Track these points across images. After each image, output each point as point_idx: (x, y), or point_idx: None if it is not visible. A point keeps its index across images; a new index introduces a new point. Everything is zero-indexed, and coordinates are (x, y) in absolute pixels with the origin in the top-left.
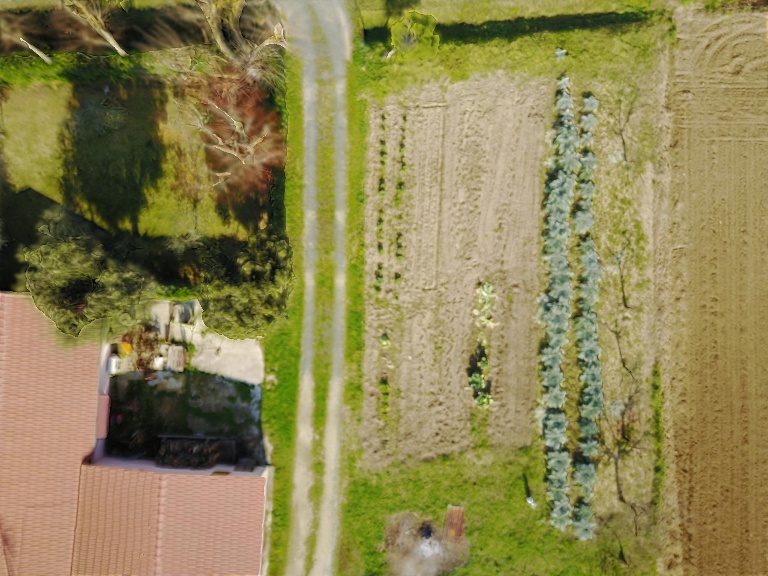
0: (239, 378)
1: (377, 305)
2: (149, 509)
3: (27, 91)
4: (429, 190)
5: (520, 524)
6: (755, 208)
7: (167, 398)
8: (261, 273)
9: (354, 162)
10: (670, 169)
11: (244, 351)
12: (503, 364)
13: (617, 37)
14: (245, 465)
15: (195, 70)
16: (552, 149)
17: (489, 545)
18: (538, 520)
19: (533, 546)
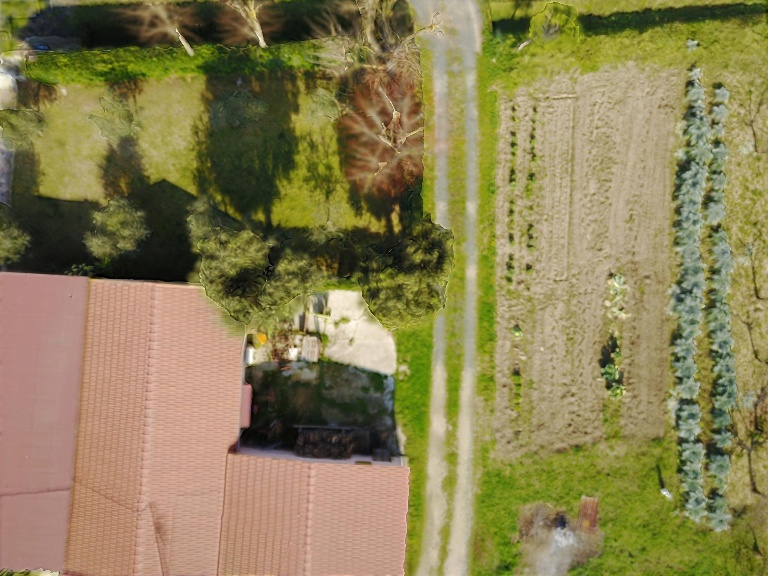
0: (372, 369)
1: (508, 296)
2: (298, 498)
3: (160, 83)
4: (559, 181)
5: (654, 515)
6: None
7: (301, 388)
8: (427, 262)
9: (485, 153)
10: None
11: (376, 342)
12: (635, 355)
13: (749, 28)
14: (382, 455)
15: (330, 62)
16: (683, 140)
17: (623, 536)
18: (672, 511)
19: (667, 537)
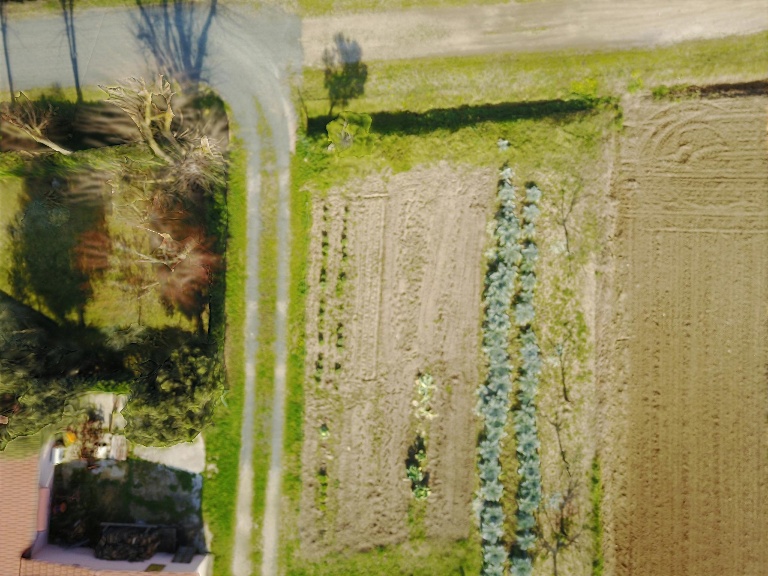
0: (181, 467)
1: (317, 395)
2: None
3: None
4: (370, 281)
5: None
6: (699, 301)
7: (110, 486)
8: (182, 388)
9: (295, 253)
10: (614, 259)
11: None
12: (442, 456)
13: (559, 127)
14: (184, 555)
15: None
16: (493, 240)
17: None
18: None
19: None
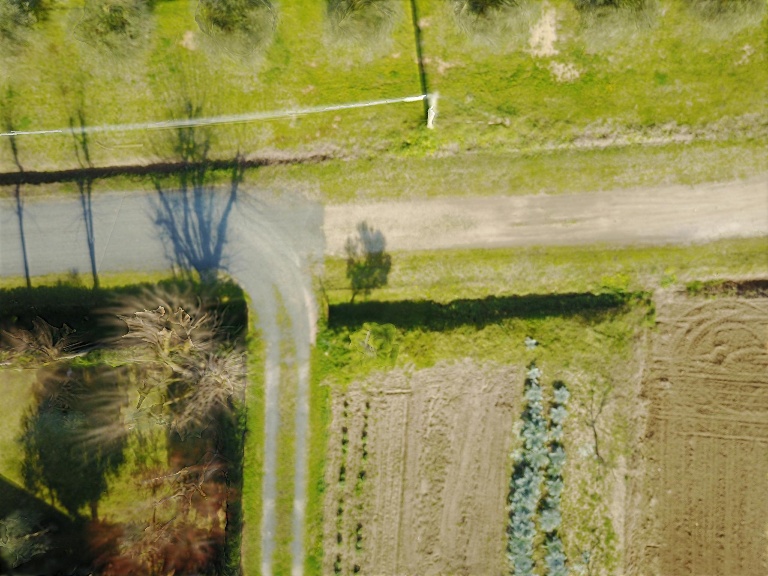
0: None
1: None
2: None
3: None
4: (391, 480)
5: None
6: (734, 512)
7: None
8: None
9: (315, 449)
10: (645, 461)
11: None
12: None
13: (590, 328)
14: None
15: (155, 360)
16: (520, 441)
17: None
18: None
19: None
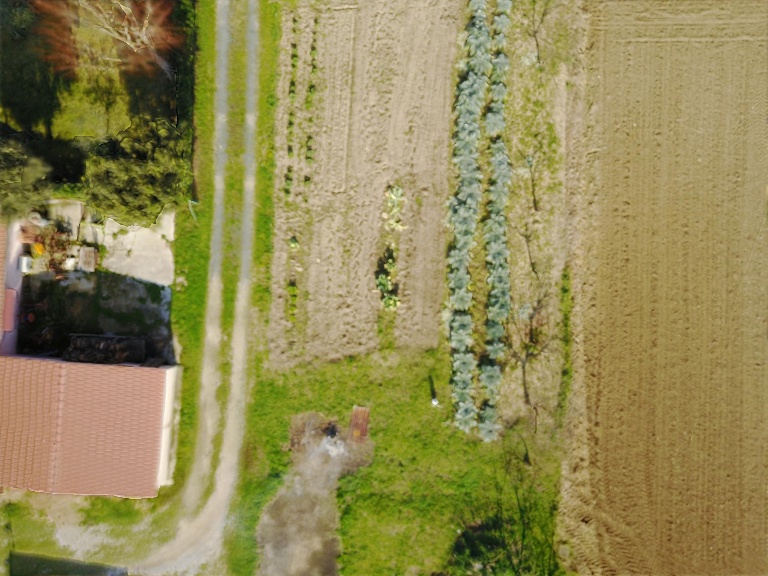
0: (149, 279)
1: (286, 208)
2: (50, 396)
3: None
4: (339, 93)
5: (426, 425)
6: (670, 110)
7: (79, 298)
8: (143, 153)
9: (264, 65)
10: (585, 72)
11: (155, 253)
12: (411, 267)
13: None
14: (153, 362)
15: None
16: (464, 51)
17: (394, 445)
18: (443, 422)
19: (438, 447)
